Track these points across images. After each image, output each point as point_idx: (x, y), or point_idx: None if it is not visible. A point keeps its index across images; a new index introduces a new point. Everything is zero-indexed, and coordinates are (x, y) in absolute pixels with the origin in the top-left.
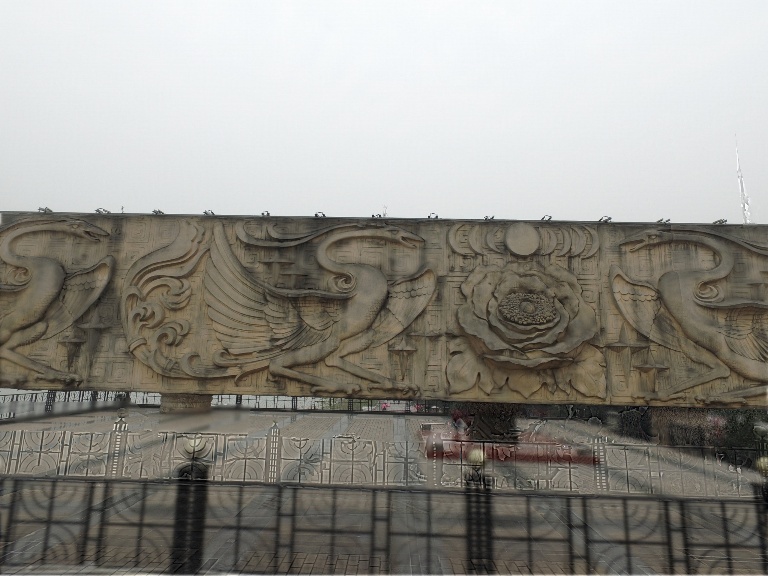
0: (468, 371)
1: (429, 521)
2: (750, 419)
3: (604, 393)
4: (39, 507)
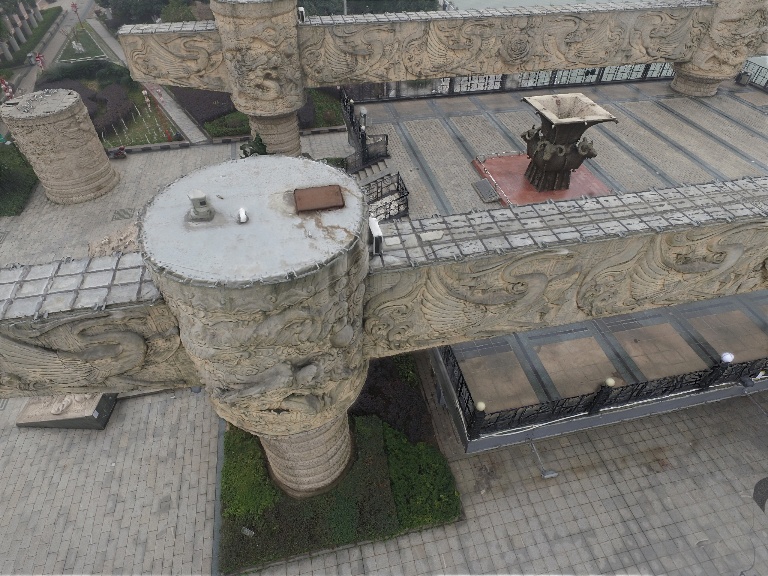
0: None
1: (760, 327)
2: None
3: None
4: None
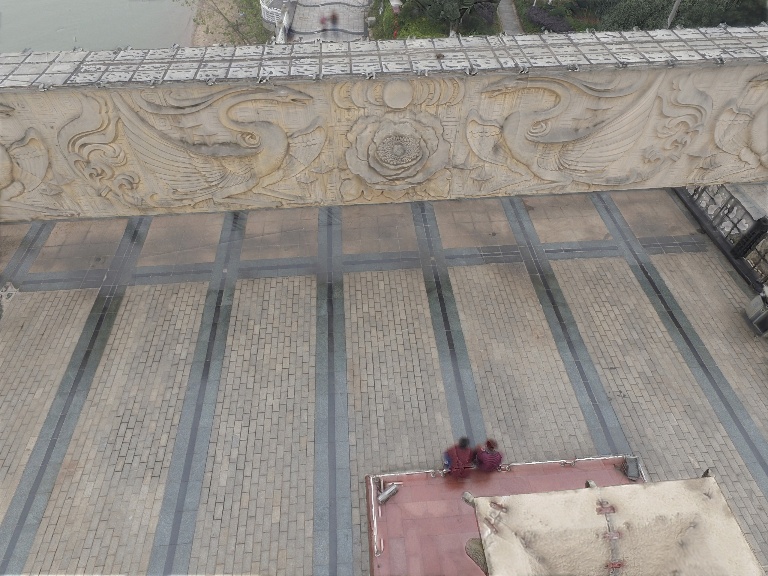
0: (355, 191)
1: (341, 234)
2: (654, 28)
3: (446, 195)
4: (87, 246)
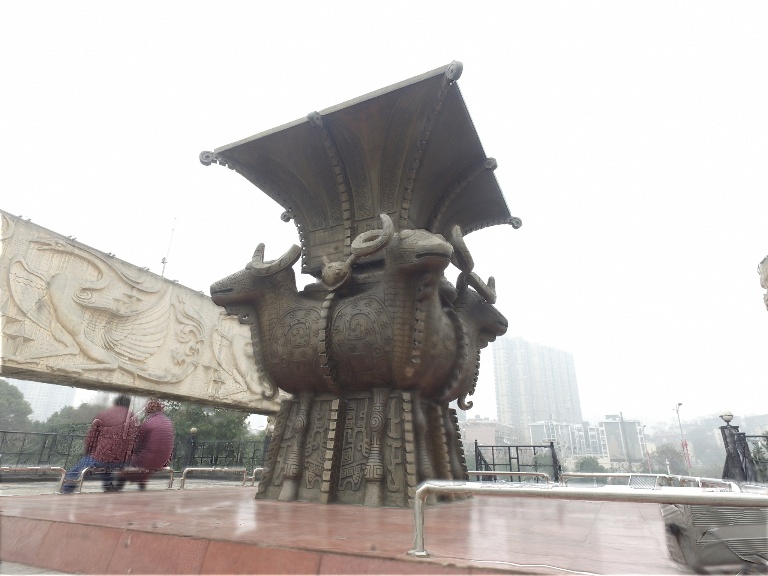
0: None
1: None
2: None
3: None
4: None
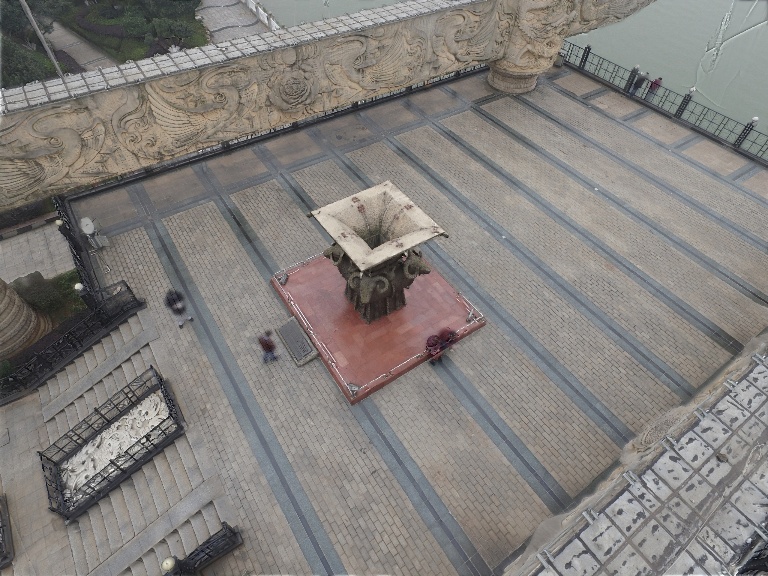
0: None
1: None
2: None
3: None
4: None
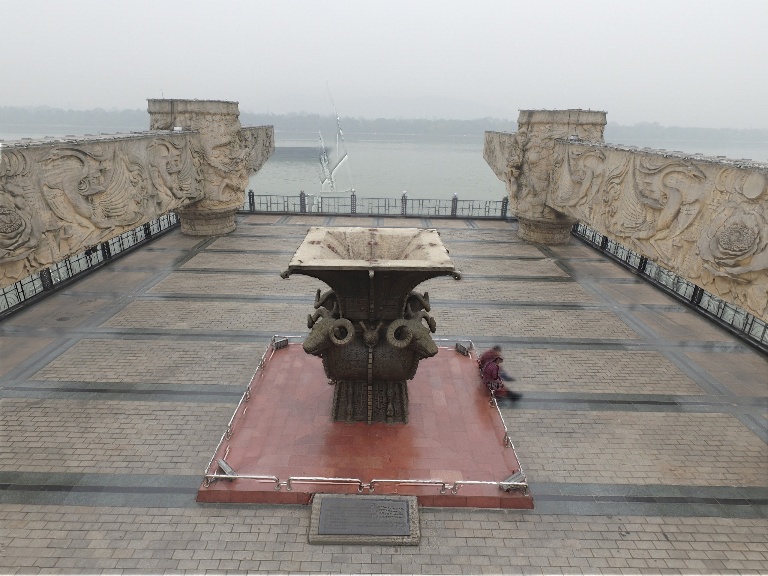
0: (696, 267)
1: (711, 352)
2: None
3: (761, 311)
4: None
